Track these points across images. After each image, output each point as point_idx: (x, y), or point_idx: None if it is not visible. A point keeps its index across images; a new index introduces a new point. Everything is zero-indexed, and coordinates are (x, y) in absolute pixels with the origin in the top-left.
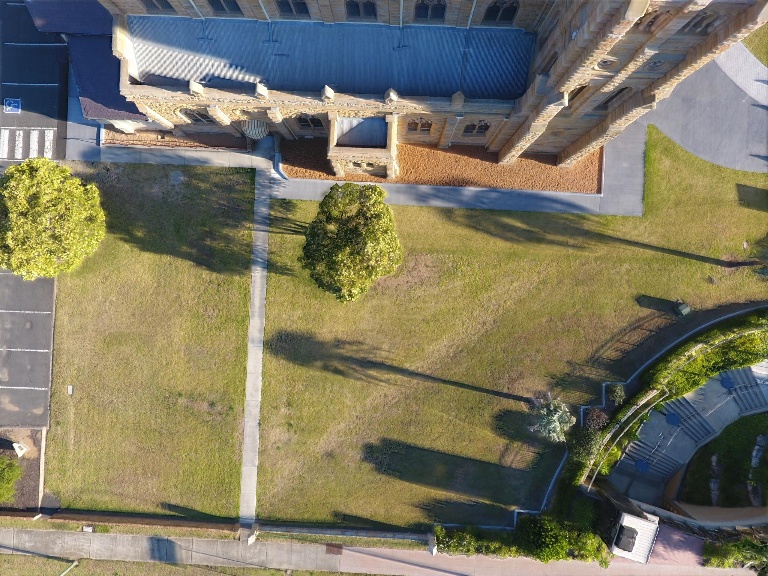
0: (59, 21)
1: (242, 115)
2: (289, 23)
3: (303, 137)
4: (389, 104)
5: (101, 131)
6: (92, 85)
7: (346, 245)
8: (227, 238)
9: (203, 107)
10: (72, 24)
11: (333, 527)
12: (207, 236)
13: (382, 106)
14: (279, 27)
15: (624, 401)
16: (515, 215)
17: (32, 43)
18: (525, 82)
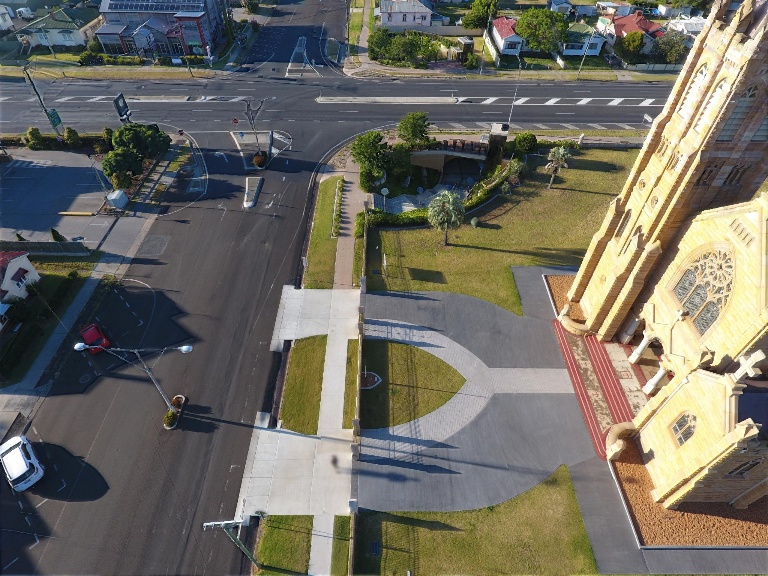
0: None
1: None
2: None
3: None
4: None
5: None
6: None
7: None
8: None
9: None
10: None
11: (631, 148)
12: None
13: None
14: None
15: (500, 186)
16: None
17: None
18: None
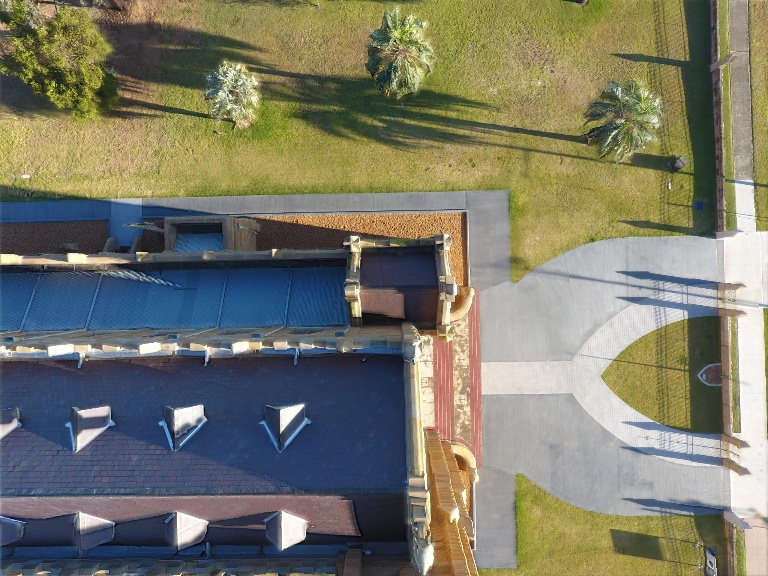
0: None
1: None
2: None
3: None
4: None
5: None
6: None
7: None
8: None
9: None
10: None
11: None
12: None
13: None
14: None
15: None
16: None
17: None
18: None
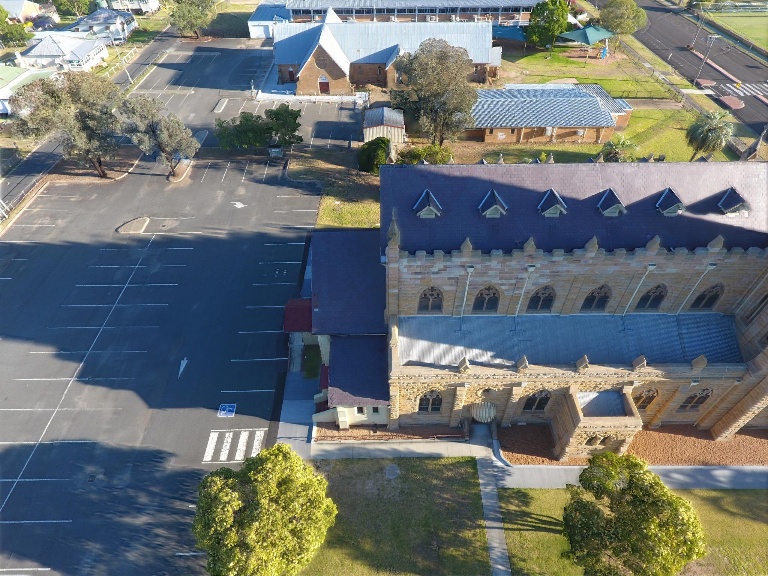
0: (334, 325)
1: (481, 396)
2: (531, 317)
3: (516, 424)
4: (636, 371)
5: (313, 429)
6: (343, 376)
7: (644, 517)
8: (457, 540)
9: (453, 387)
10: (344, 327)
11: None
12: (433, 539)
13: (627, 375)
14: (523, 320)
15: None
16: (763, 494)
17: (255, 359)
18: (739, 352)
